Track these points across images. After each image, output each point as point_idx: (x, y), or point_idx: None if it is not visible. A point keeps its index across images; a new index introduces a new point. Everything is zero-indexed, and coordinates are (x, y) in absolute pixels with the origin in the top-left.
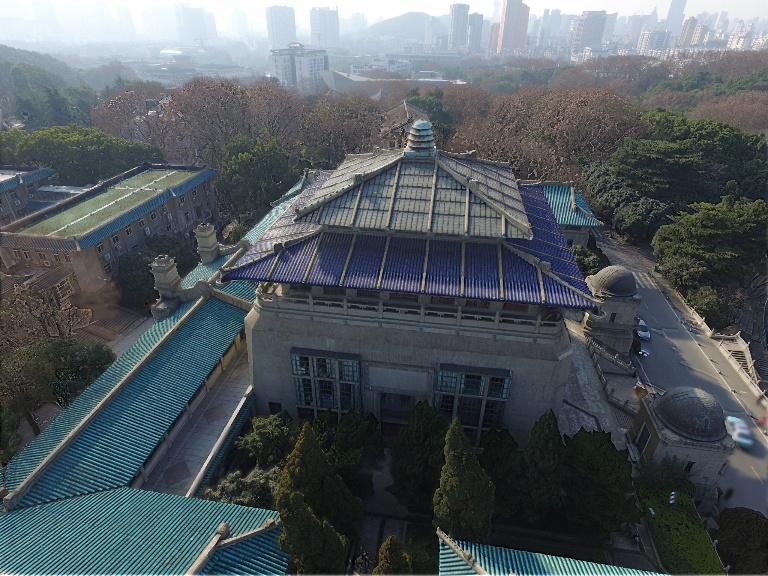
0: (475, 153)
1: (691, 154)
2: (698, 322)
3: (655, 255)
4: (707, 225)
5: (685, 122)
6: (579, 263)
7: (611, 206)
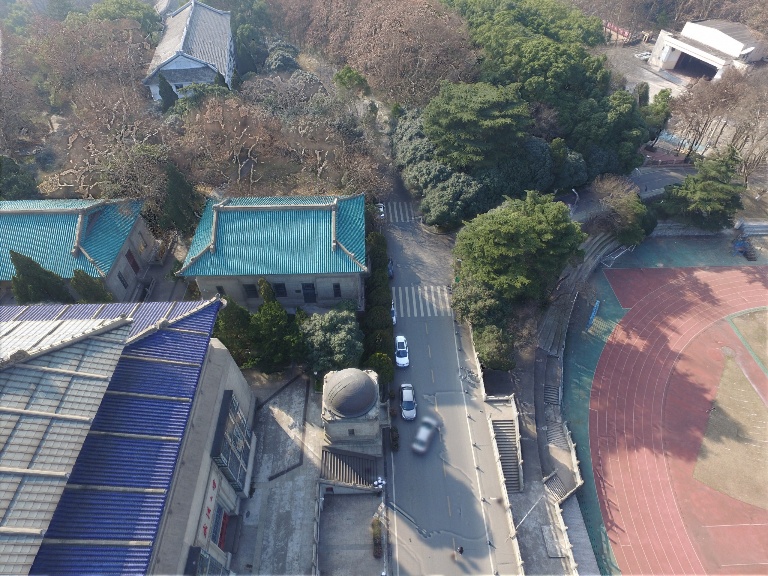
0: (20, 352)
1: (512, 108)
2: (478, 374)
3: (453, 268)
4: (499, 243)
5: (520, 45)
6: (324, 345)
7: (419, 186)
